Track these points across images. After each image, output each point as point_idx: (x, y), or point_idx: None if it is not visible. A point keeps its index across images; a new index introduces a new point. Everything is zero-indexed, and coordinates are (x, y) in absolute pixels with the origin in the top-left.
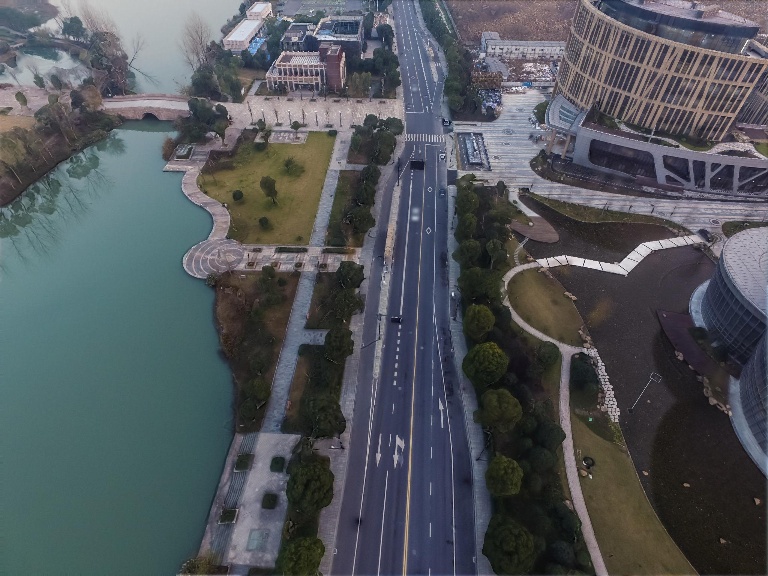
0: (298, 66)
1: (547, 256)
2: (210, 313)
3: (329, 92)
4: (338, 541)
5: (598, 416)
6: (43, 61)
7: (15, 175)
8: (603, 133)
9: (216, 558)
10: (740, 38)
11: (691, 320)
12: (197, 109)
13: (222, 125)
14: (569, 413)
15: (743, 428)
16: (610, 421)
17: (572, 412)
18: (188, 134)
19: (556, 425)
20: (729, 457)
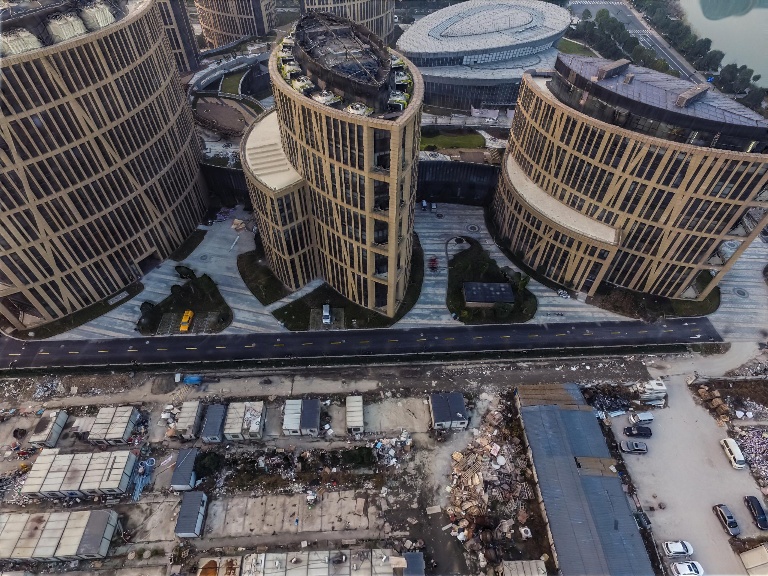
0: None
1: None
2: None
3: None
4: None
5: None
6: None
7: None
8: None
9: None
10: None
11: None
12: None
13: None
14: None
15: None
16: None
17: None
18: None
19: None
20: None
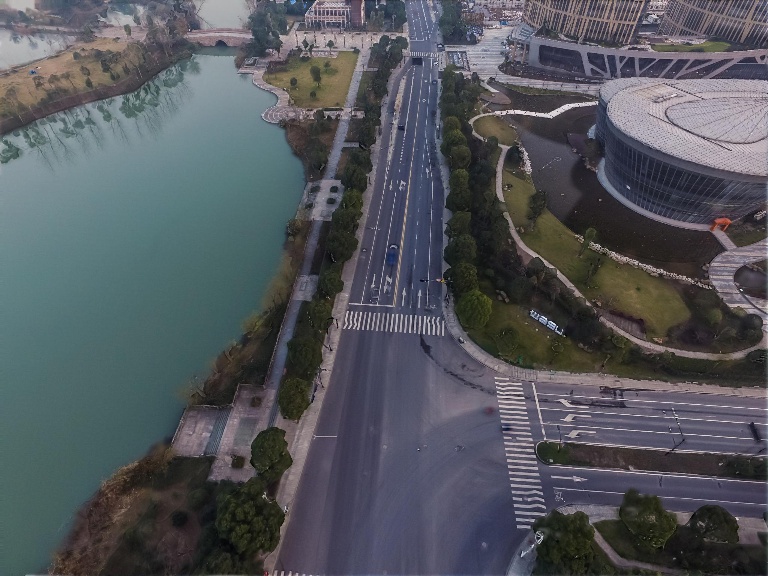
0: (329, 8)
1: (502, 110)
2: (284, 138)
3: (352, 28)
4: (369, 213)
5: (519, 171)
6: (124, 15)
7: (139, 72)
8: (547, 39)
9: (305, 219)
10: None
11: (587, 136)
12: (258, 35)
13: (279, 41)
14: (502, 170)
15: (602, 176)
16: (525, 173)
17: (504, 169)
18: (253, 49)
19: (491, 166)
20: (591, 186)
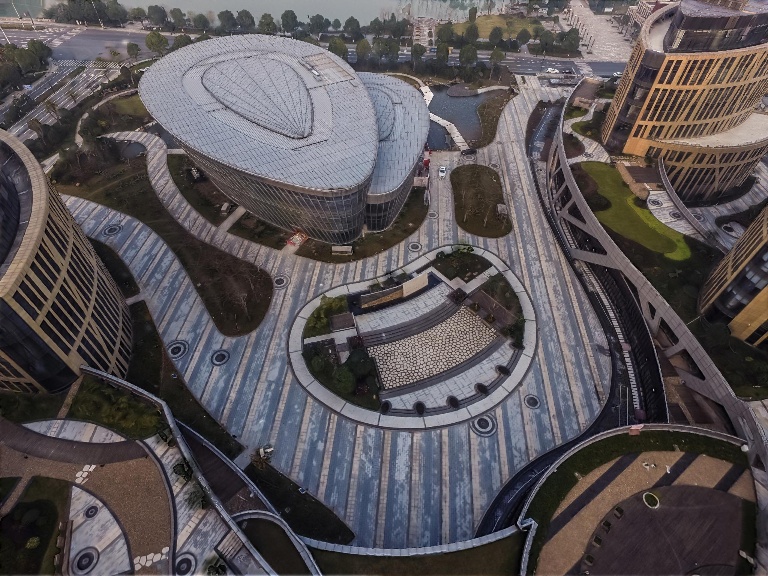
0: None
1: (433, 91)
2: None
3: None
4: None
5: None
6: None
7: None
8: None
9: None
10: None
11: None
12: None
13: None
14: None
15: None
16: None
17: None
18: None
19: None
20: None
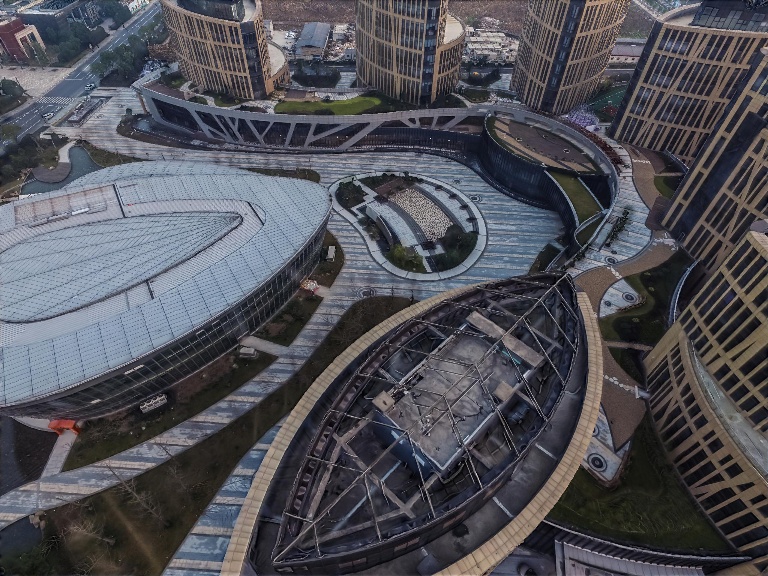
0: None
1: None
2: None
3: (12, 61)
4: None
5: None
6: None
7: None
8: (152, 91)
9: None
10: (224, 4)
11: None
12: None
13: None
14: None
15: None
16: None
17: None
18: None
19: None
20: None
